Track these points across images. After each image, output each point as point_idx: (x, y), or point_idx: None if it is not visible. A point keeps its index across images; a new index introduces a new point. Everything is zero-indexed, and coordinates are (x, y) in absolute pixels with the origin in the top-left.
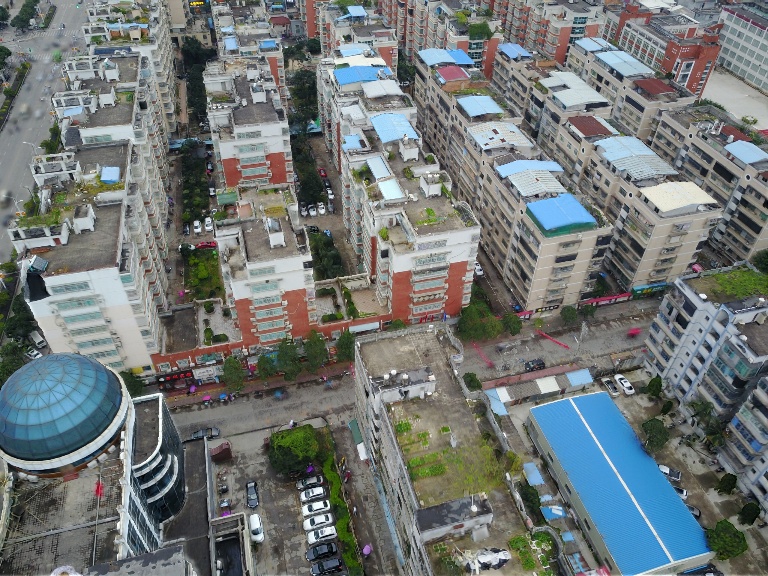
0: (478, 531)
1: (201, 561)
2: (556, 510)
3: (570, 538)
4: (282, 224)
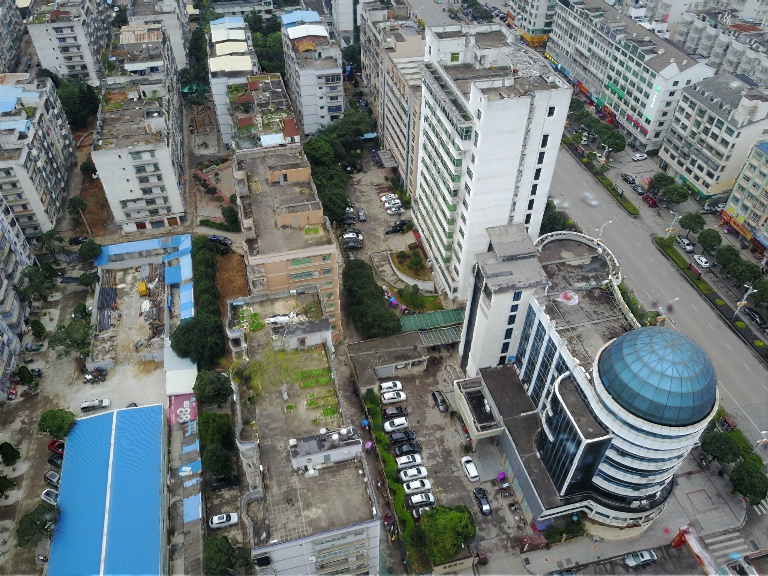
0: None
1: (501, 401)
2: (186, 470)
3: (186, 448)
4: None
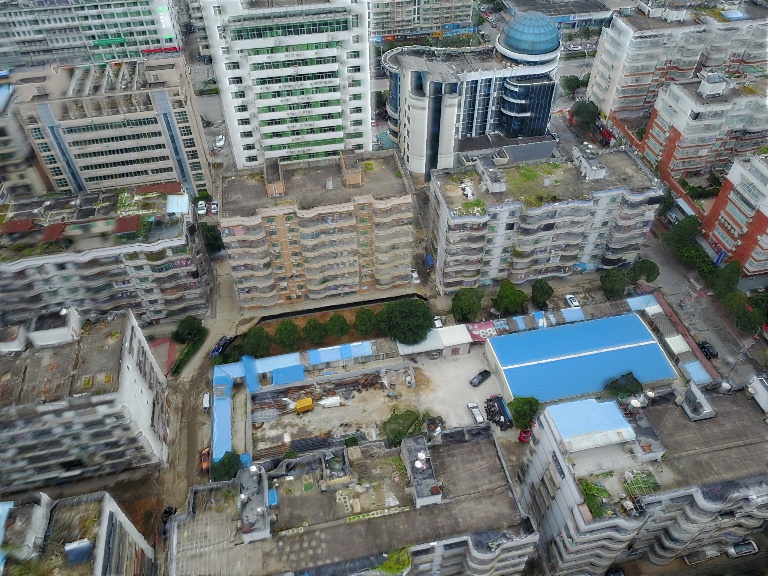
0: (483, 184)
1: (480, 147)
2: (543, 322)
3: (521, 327)
4: (732, 95)
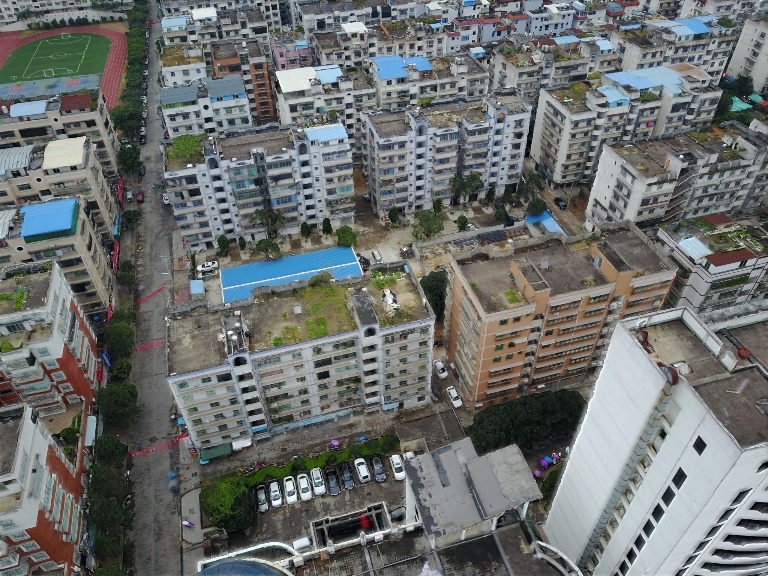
0: (373, 299)
1: None
2: None
3: None
4: None
